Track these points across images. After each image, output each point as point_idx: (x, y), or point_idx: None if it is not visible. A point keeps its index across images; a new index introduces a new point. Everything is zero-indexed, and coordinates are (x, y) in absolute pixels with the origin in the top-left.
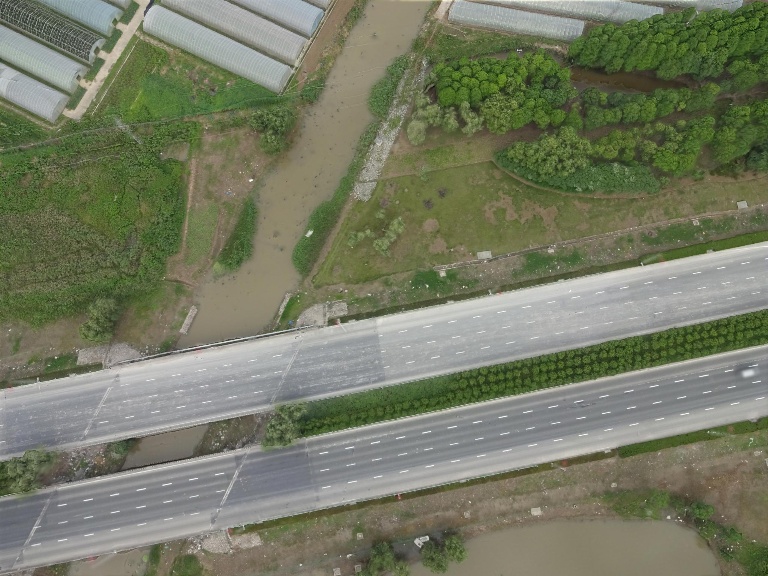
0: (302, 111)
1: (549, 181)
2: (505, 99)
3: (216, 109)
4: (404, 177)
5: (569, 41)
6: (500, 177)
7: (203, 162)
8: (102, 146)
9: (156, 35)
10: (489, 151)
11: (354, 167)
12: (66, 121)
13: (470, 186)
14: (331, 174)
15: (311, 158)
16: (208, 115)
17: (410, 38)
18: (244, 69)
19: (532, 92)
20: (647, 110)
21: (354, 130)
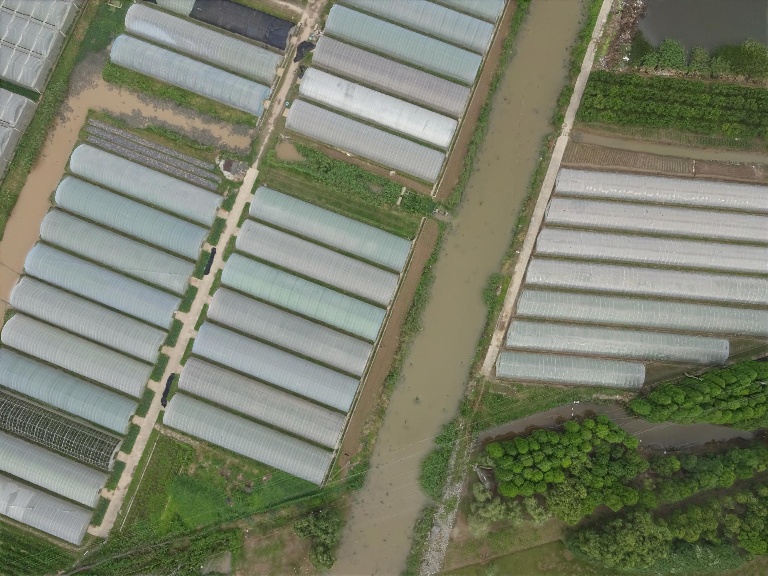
0: (348, 499)
1: (627, 571)
2: (572, 484)
3: (255, 511)
4: (468, 568)
5: (630, 388)
6: (571, 558)
7: (248, 573)
8: (136, 568)
9: (178, 429)
10: (556, 528)
11: (413, 562)
12: (93, 541)
13: (540, 572)
14: (389, 571)
15: (365, 553)
16: (247, 518)
17: (456, 399)
18: (281, 466)
19: (600, 472)
20: (726, 482)
21: (407, 516)
